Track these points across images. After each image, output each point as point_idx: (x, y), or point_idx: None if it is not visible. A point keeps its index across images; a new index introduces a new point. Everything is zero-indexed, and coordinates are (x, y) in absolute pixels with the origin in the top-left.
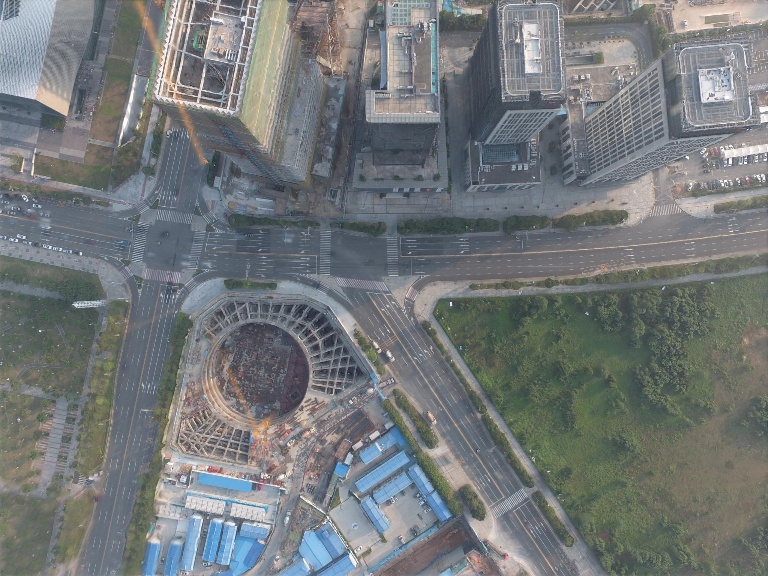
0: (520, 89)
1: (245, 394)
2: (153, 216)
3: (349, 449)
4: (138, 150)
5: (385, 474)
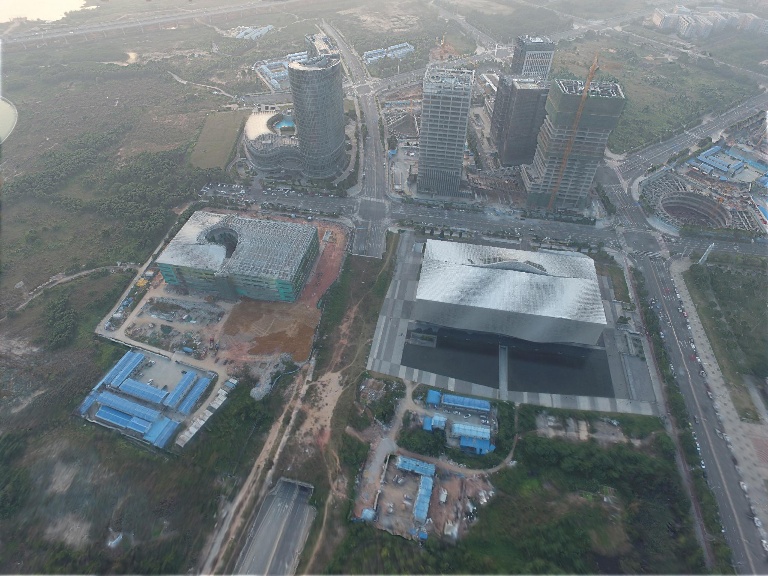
0: None
1: None
2: (627, 248)
3: None
4: None
5: None
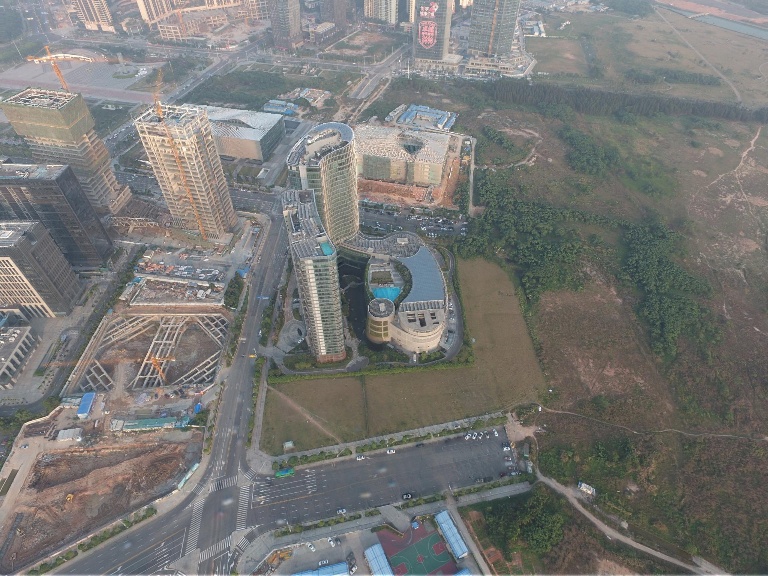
0: None
1: None
2: None
3: None
4: (133, 166)
5: None
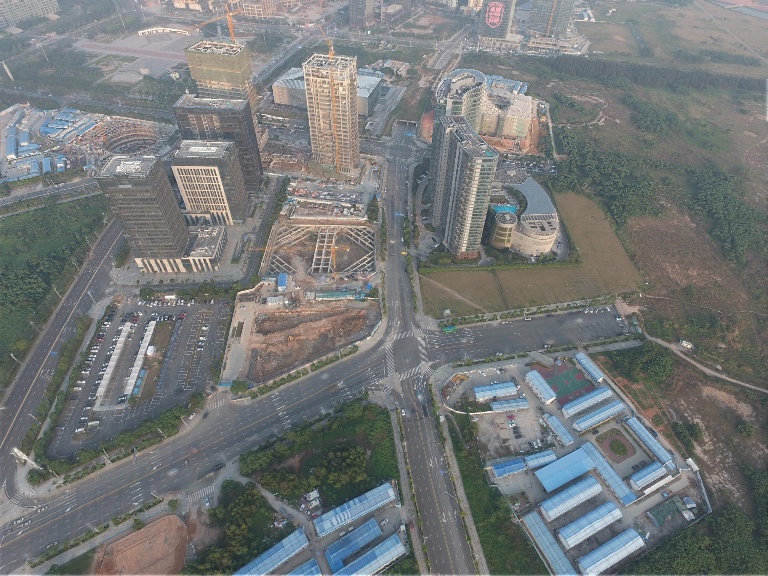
0: None
1: (129, 150)
2: None
3: (69, 159)
4: None
5: (44, 165)
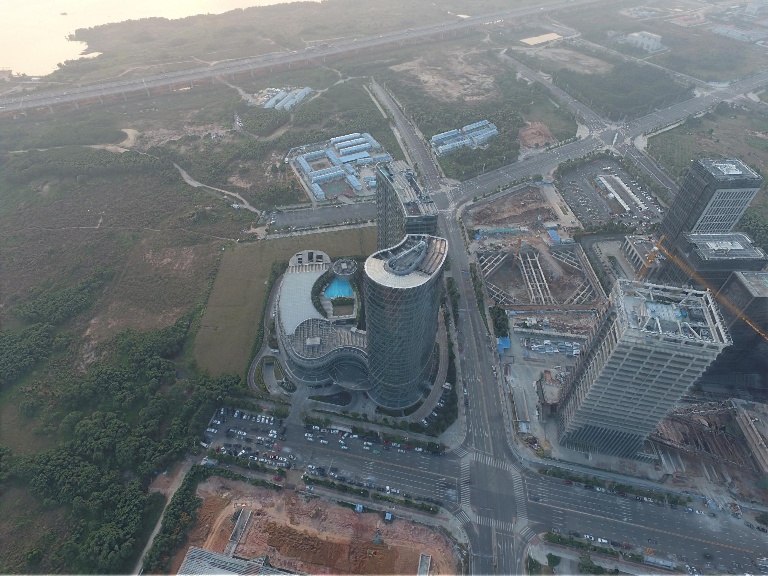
0: (755, 252)
1: None
2: None
3: None
4: None
5: None
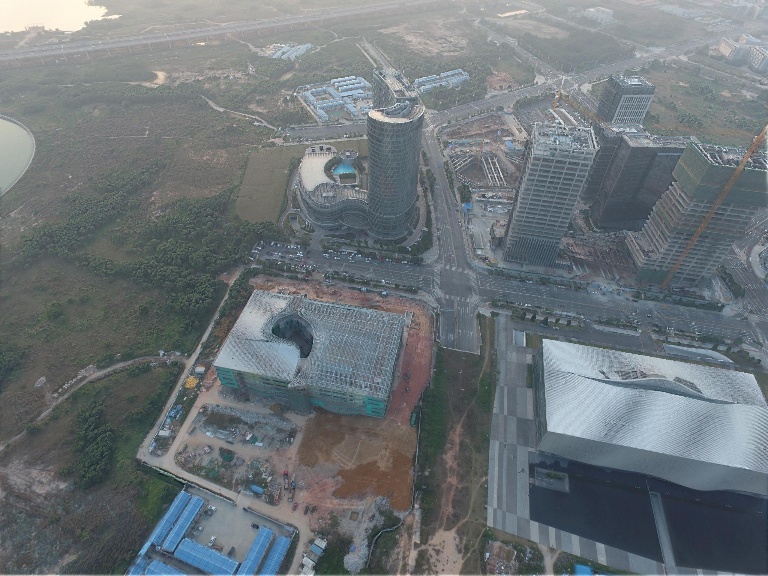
0: None
1: None
2: (767, 345)
3: None
4: None
5: None
